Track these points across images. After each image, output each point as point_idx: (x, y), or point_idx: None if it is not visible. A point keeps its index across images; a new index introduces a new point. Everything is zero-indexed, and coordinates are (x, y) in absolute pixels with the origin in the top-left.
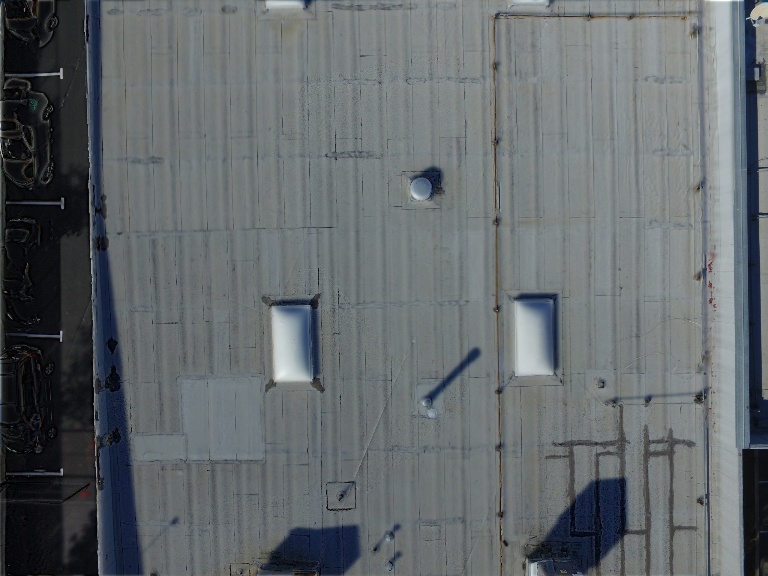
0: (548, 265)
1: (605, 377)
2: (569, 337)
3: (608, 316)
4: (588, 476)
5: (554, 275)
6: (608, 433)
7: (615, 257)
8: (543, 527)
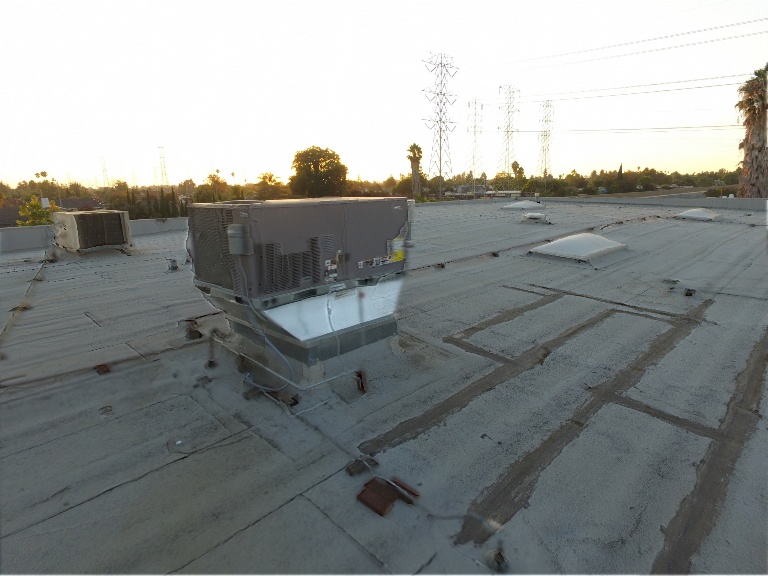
0: (637, 244)
1: (685, 282)
2: (636, 262)
3: (718, 268)
4: (571, 316)
5: (642, 247)
6: (660, 306)
7: (748, 256)
8: (403, 313)
